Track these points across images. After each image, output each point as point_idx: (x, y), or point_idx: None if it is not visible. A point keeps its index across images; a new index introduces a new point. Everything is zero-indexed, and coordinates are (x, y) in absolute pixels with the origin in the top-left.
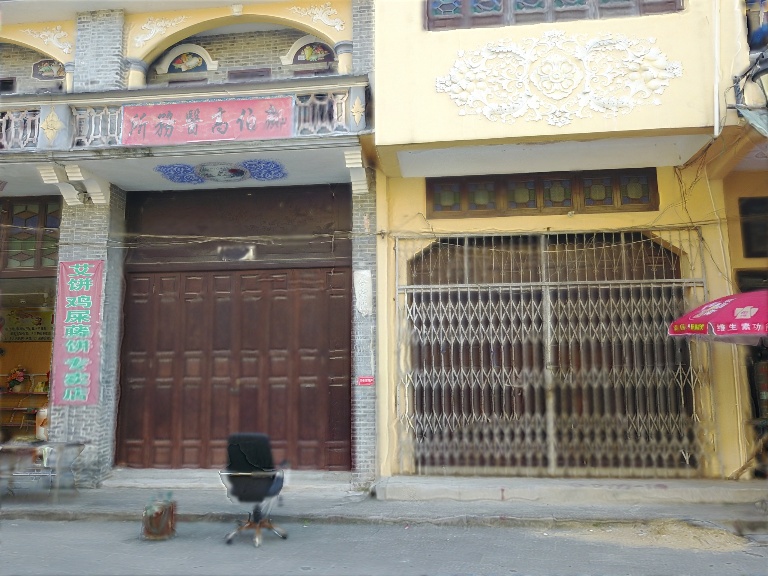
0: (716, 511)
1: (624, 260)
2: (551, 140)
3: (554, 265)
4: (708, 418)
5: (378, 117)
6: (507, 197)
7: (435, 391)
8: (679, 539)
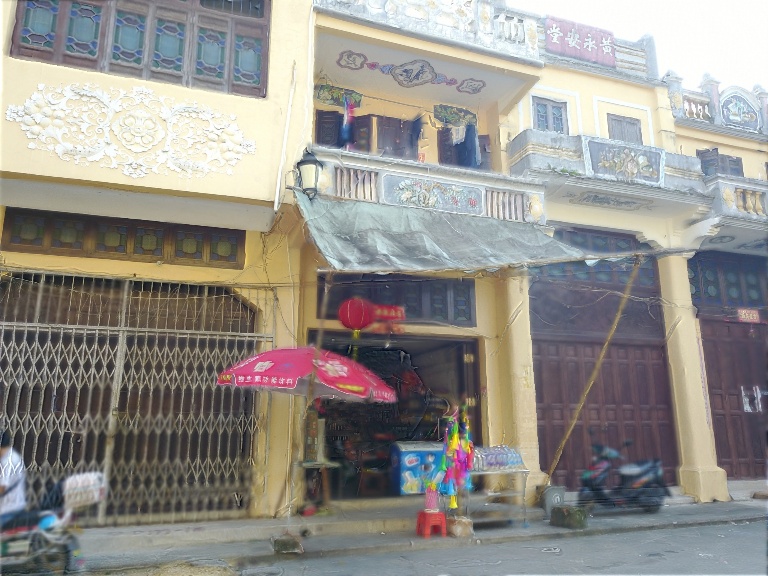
0: (239, 549)
1: (205, 312)
2: None
3: (135, 311)
4: (262, 462)
5: None
6: (96, 239)
7: None
8: None
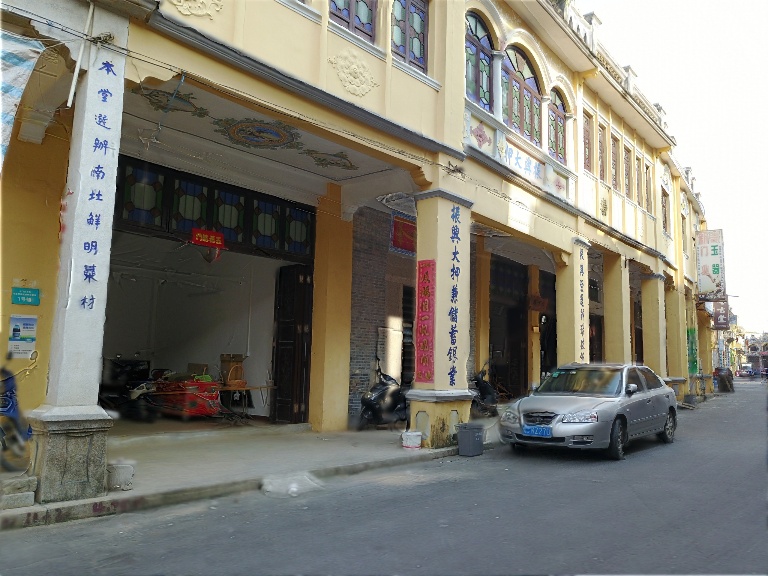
0: None
1: None
2: None
3: None
4: None
5: None
6: None
7: None
8: None
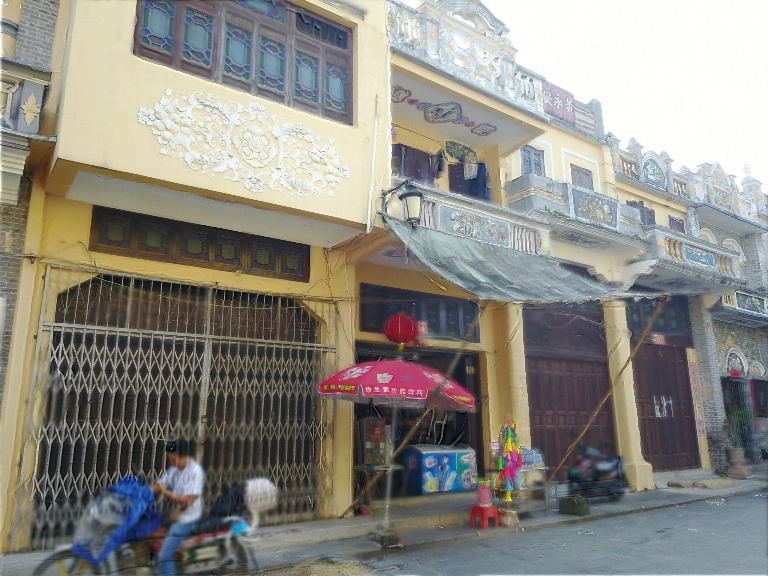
0: (341, 547)
1: (279, 322)
2: (231, 200)
3: (219, 319)
4: (330, 466)
5: (65, 127)
6: (181, 245)
7: (75, 447)
8: (328, 575)
